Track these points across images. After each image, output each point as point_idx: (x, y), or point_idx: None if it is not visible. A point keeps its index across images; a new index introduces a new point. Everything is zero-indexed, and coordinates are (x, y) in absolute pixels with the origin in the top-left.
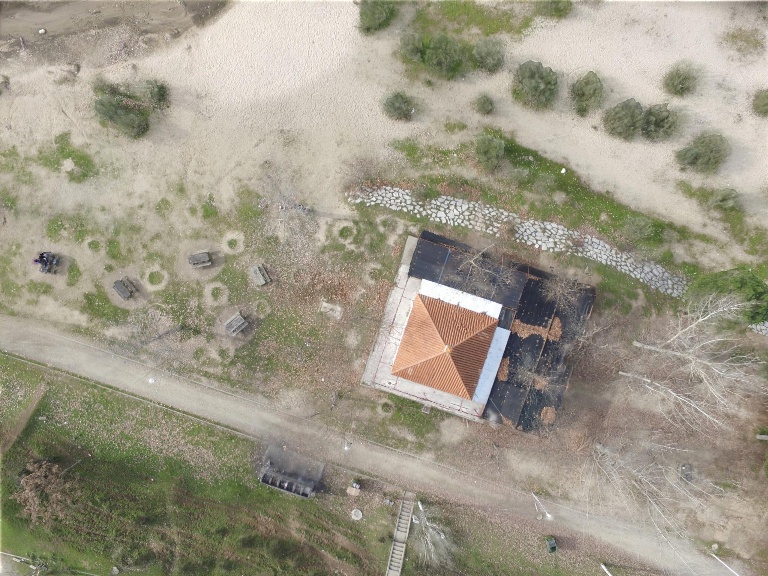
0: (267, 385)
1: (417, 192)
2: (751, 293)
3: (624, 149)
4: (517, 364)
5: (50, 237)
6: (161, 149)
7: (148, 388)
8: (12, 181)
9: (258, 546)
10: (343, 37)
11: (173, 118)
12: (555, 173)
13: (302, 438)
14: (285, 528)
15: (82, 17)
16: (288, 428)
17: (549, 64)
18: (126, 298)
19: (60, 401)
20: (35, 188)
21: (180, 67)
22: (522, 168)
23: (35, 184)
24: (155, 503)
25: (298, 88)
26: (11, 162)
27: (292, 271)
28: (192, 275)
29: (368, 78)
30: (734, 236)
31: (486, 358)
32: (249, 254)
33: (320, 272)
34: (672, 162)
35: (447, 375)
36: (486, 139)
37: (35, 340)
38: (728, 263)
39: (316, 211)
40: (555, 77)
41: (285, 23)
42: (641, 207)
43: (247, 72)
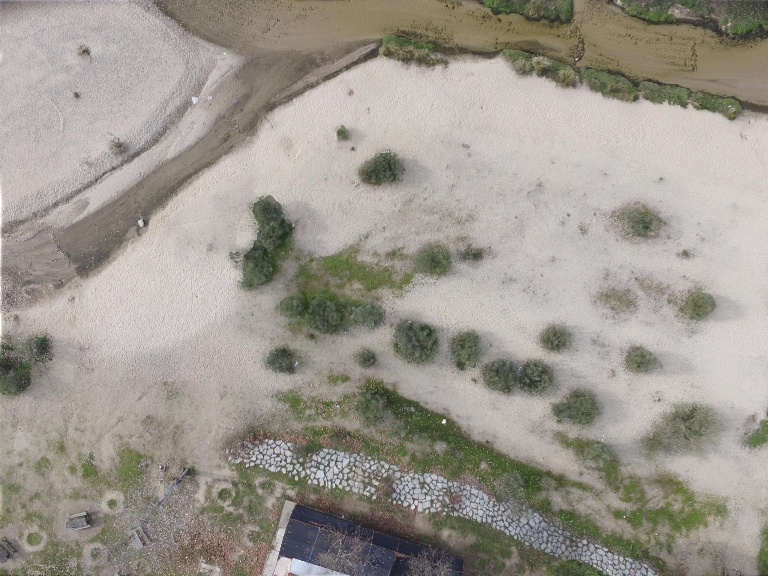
0: None
1: (299, 446)
2: None
3: (503, 401)
4: None
5: None
6: (42, 405)
7: None
8: None
9: None
10: (226, 292)
11: (55, 371)
12: (436, 423)
13: None
14: None
15: None
16: None
17: (430, 319)
18: (3, 562)
19: None
20: None
21: (63, 319)
22: (404, 419)
23: None
24: None
25: (182, 341)
26: None
27: (172, 531)
28: (71, 535)
29: (252, 331)
30: (609, 484)
31: None
32: (129, 514)
33: (199, 532)
34: (549, 414)
35: None
36: (364, 402)
37: None
38: (603, 510)
39: (196, 471)
40: (431, 343)
41: (168, 278)
42: (520, 456)
43: (130, 325)
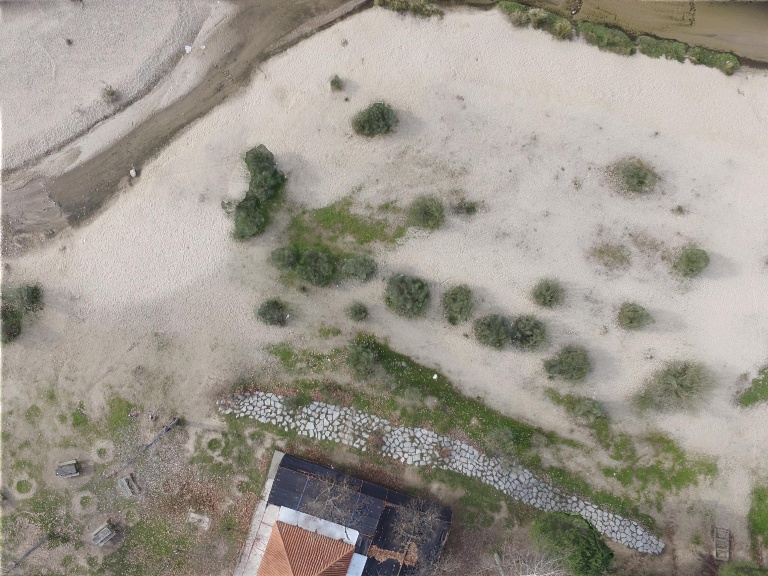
0: None
1: (290, 398)
2: (579, 558)
3: (494, 357)
4: None
5: None
6: (33, 353)
7: None
8: None
9: None
10: (218, 243)
11: (46, 320)
12: (427, 378)
13: None
14: None
15: None
16: None
17: (422, 273)
18: None
19: None
20: None
21: (54, 268)
22: (395, 373)
23: None
24: None
25: (173, 292)
26: None
27: (161, 481)
28: (61, 484)
29: (243, 283)
30: (600, 442)
31: None
32: (118, 463)
33: (189, 482)
34: (541, 370)
35: None
36: (354, 354)
37: None
38: (594, 467)
39: (186, 421)
40: (423, 295)
41: (160, 228)
42: (511, 412)
43: (121, 276)
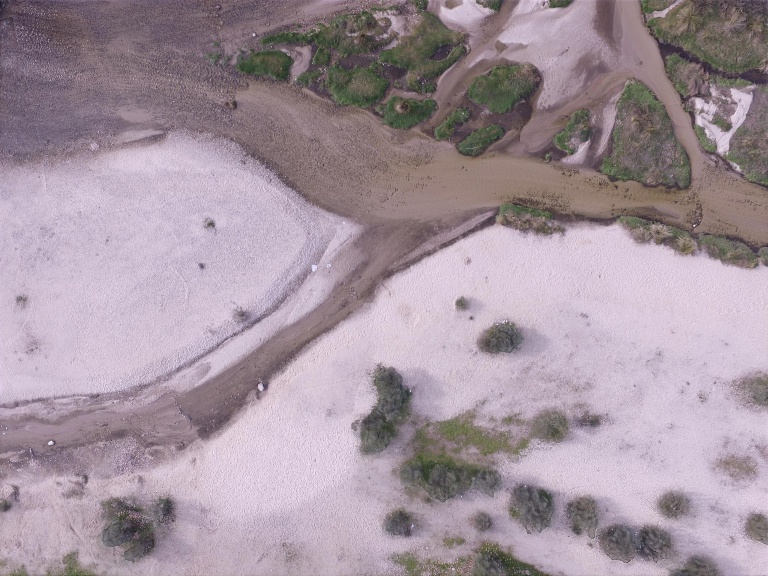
0: None
1: None
2: None
3: (619, 566)
4: None
5: None
6: (166, 567)
7: None
8: None
9: None
10: (344, 456)
11: (178, 532)
12: None
13: None
14: None
15: (90, 429)
16: None
17: (545, 483)
18: None
19: None
20: None
21: (185, 480)
22: None
23: None
24: None
25: (300, 503)
26: None
27: None
28: None
29: (368, 494)
30: None
31: None
32: None
33: None
34: None
35: None
36: (483, 572)
37: None
38: None
39: None
40: (551, 514)
41: (288, 442)
42: None
43: (250, 488)
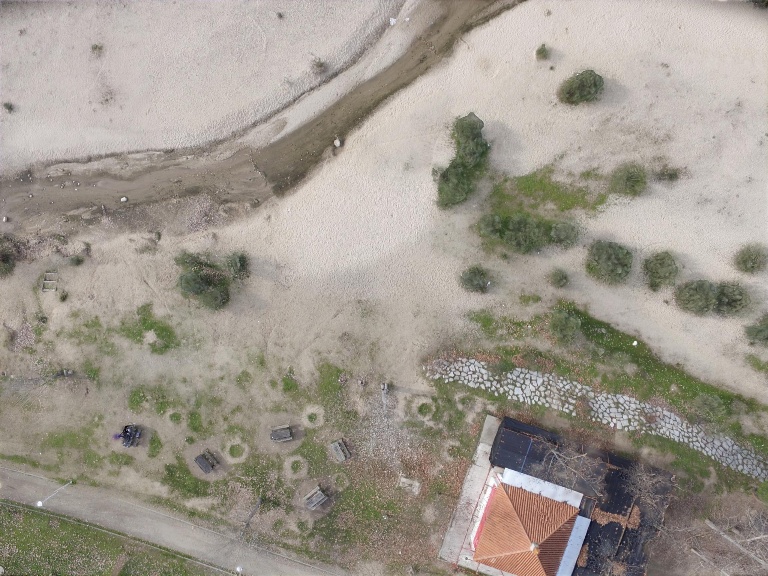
0: (345, 557)
1: (492, 364)
2: None
3: (695, 323)
4: (596, 551)
5: (132, 409)
6: (241, 320)
7: (227, 558)
8: (95, 352)
9: None
10: (421, 211)
11: (253, 288)
12: (627, 345)
13: None
14: None
15: (163, 186)
16: None
17: (623, 240)
18: (208, 472)
19: (140, 571)
20: (117, 359)
21: (260, 237)
22: (595, 340)
23: (117, 355)
24: None
25: (376, 259)
26: (94, 333)
27: (371, 446)
28: (272, 448)
29: (445, 251)
30: None
31: (567, 546)
32: (329, 428)
33: (399, 447)
34: (741, 336)
35: (530, 567)
36: (563, 319)
37: (116, 510)
38: None
39: (395, 386)
40: (631, 260)
41: (364, 196)
42: (710, 379)
43: (326, 244)
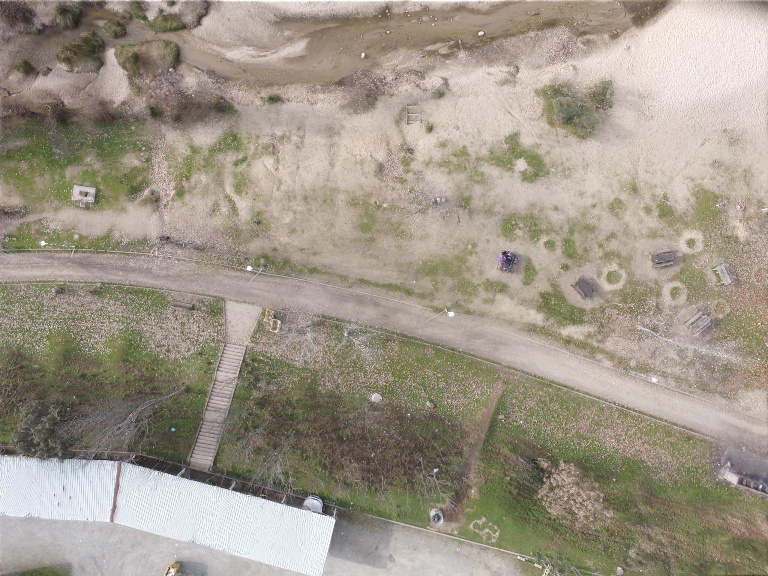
0: (725, 385)
1: None
2: None
3: None
4: None
5: (505, 236)
6: (608, 149)
7: (603, 388)
8: (466, 181)
9: (741, 548)
10: None
11: (616, 118)
12: None
13: (762, 439)
14: (757, 531)
15: (521, 19)
16: (747, 429)
17: None
18: (588, 297)
19: (516, 400)
20: (487, 188)
21: (621, 67)
22: None
23: (487, 184)
24: (627, 503)
25: (742, 87)
26: (463, 162)
27: (753, 271)
28: (650, 274)
29: None
30: None
31: None
32: (708, 253)
33: None
34: None
35: None
36: None
37: (490, 339)
38: None
39: None
40: None
41: (731, 23)
42: None
43: (691, 72)
